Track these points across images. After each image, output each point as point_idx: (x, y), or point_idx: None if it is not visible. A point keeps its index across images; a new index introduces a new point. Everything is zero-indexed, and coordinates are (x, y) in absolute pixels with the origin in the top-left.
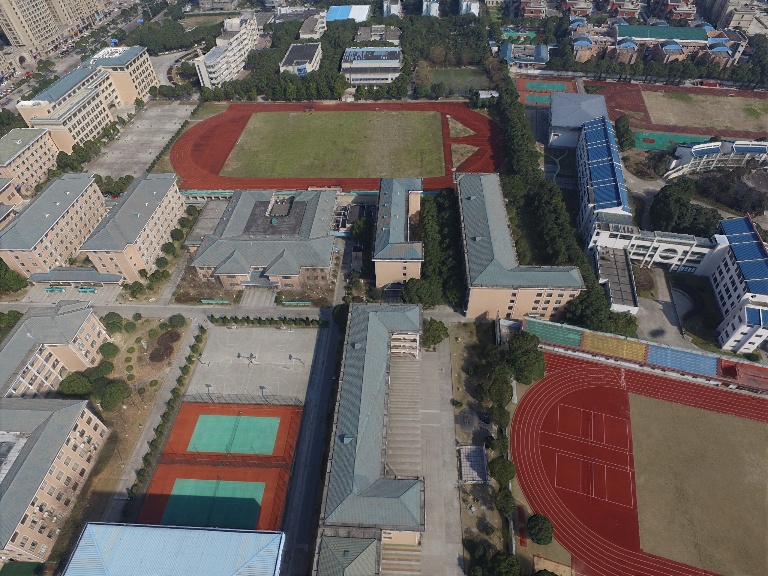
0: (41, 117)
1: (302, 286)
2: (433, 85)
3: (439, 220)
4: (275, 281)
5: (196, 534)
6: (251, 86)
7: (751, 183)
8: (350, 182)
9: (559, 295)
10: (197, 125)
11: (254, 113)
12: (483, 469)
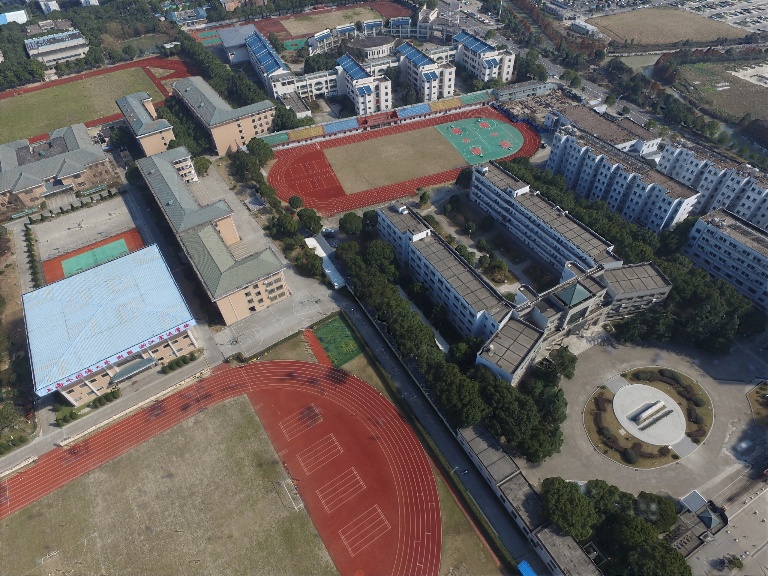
0: None
1: (93, 183)
2: (123, 48)
3: (173, 113)
4: (69, 184)
5: (102, 266)
6: None
7: (352, 46)
8: (91, 123)
9: (265, 117)
10: None
11: None
12: (260, 203)
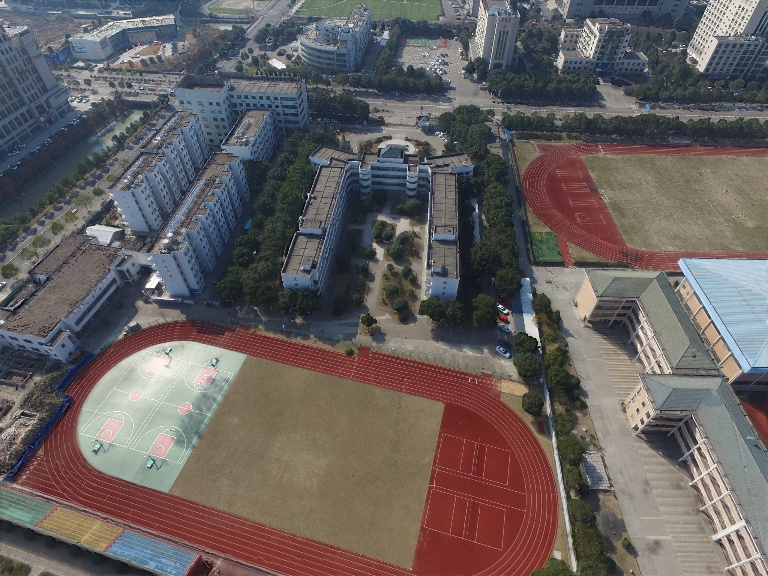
0: None
1: None
2: None
3: None
4: None
5: None
6: None
7: None
8: None
9: None
10: None
11: None
12: None
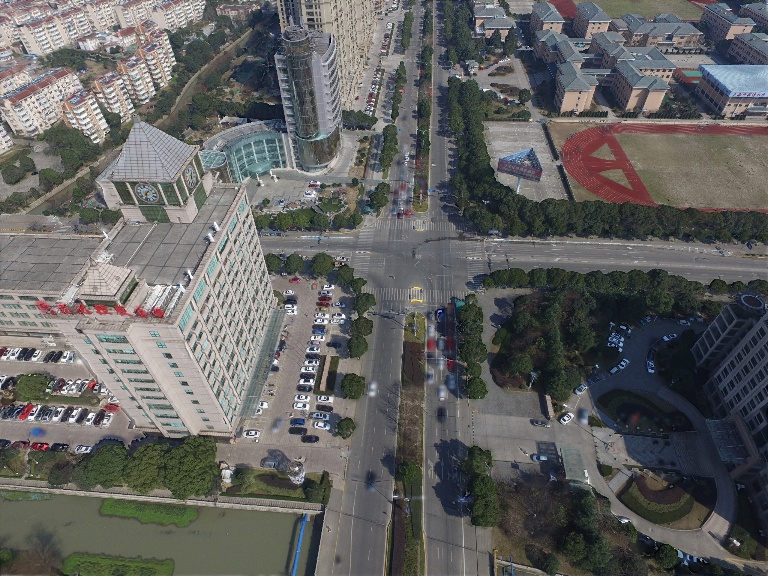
0: None
1: None
2: None
3: None
4: (675, 41)
5: (742, 65)
6: None
7: None
8: None
9: None
10: None
11: None
12: None
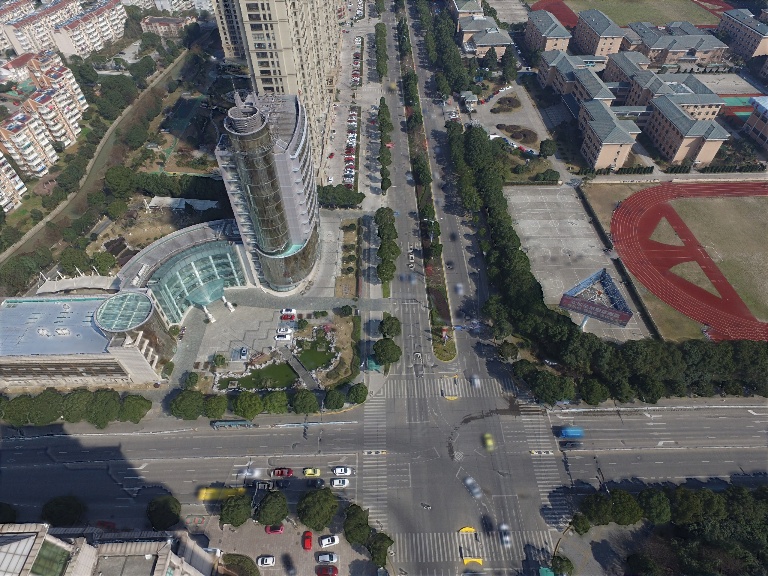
0: None
1: None
2: None
3: None
4: (697, 56)
5: None
6: None
7: None
8: None
9: None
10: (533, 6)
11: (563, 1)
12: None
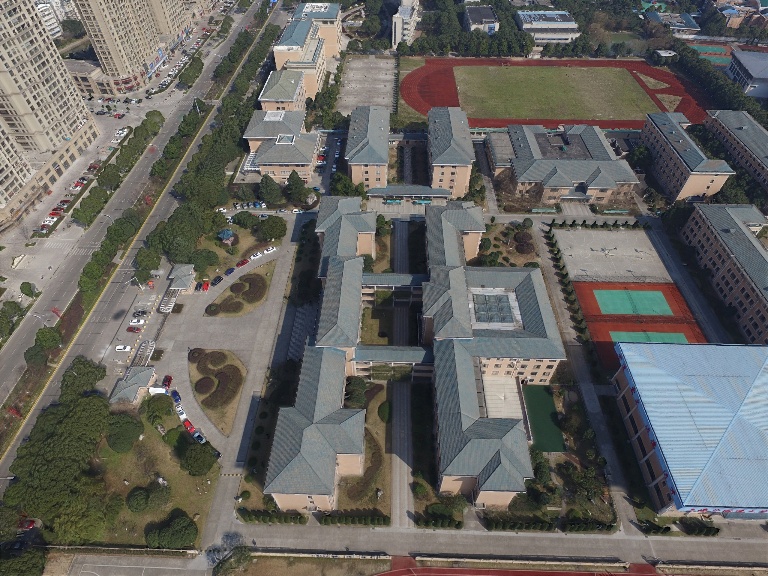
0: (293, 61)
1: (608, 200)
2: (615, 44)
3: (707, 148)
4: (591, 194)
5: (709, 347)
6: (445, 42)
7: None
8: (587, 123)
9: None
10: (408, 76)
11: (454, 66)
12: None
